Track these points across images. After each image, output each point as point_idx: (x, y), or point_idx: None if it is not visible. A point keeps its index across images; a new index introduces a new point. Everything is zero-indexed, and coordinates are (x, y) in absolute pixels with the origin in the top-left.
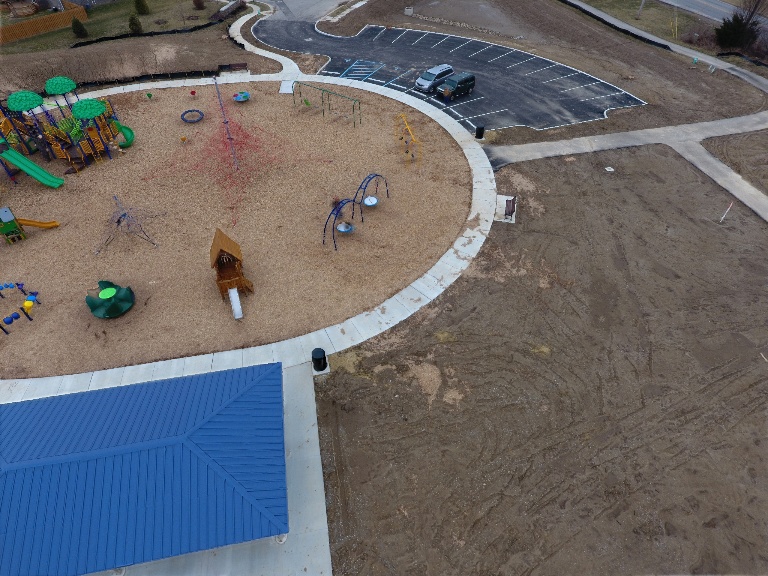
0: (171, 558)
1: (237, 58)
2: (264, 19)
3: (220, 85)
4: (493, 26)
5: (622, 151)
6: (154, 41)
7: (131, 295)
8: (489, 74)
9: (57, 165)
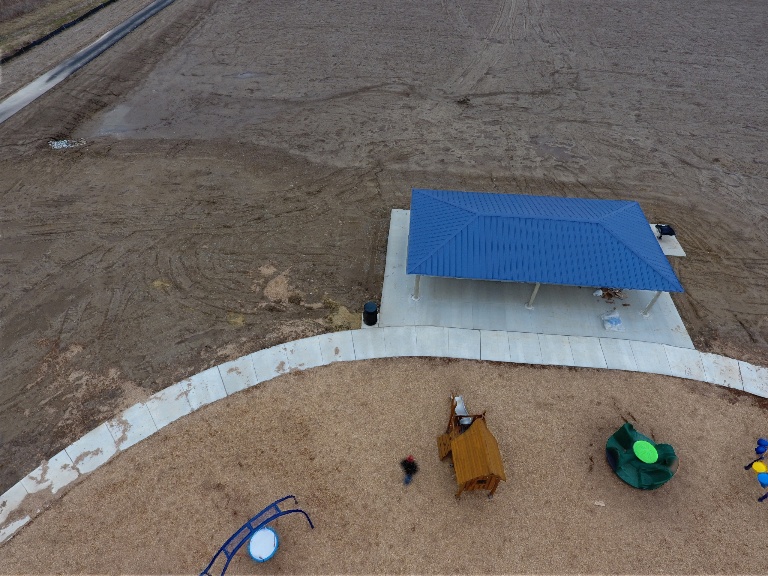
0: None
1: None
2: None
3: None
4: None
5: None
6: None
7: (615, 463)
8: None
9: None
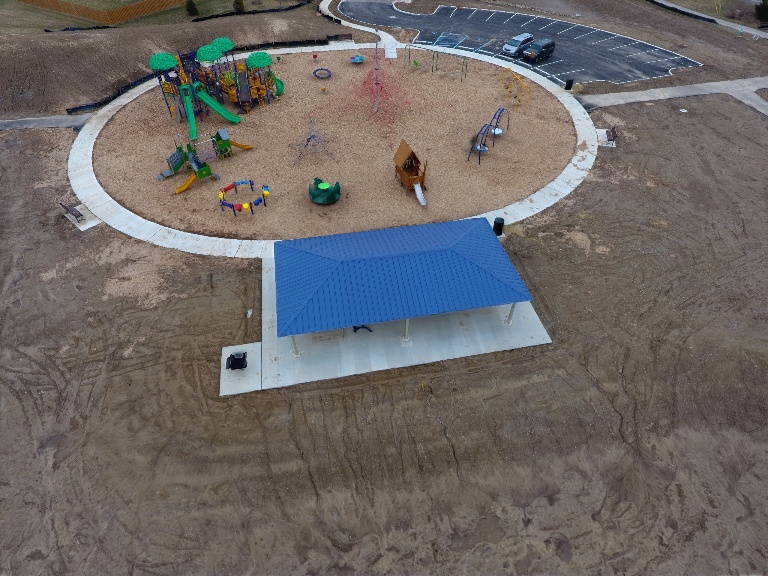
0: (438, 332)
1: (339, 31)
2: (345, 1)
3: (333, 51)
4: (550, 7)
5: (691, 98)
6: (266, 16)
7: None
8: (561, 43)
9: (227, 108)
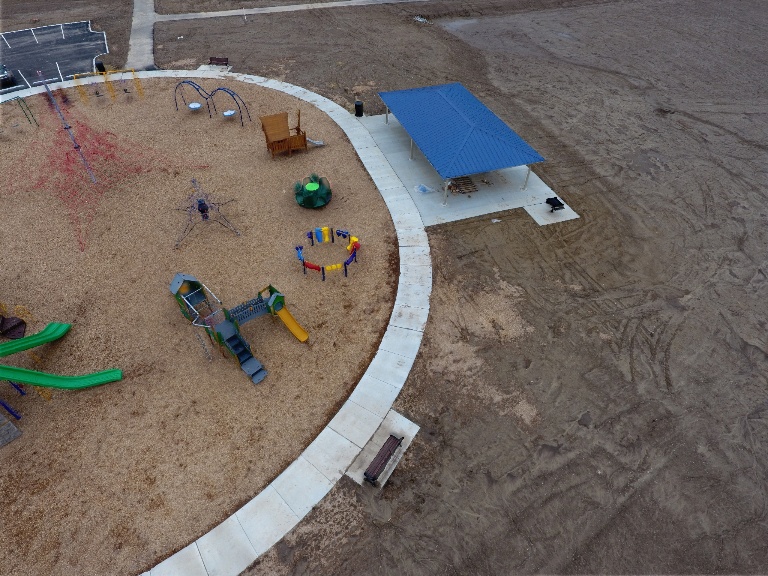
0: None
1: None
2: None
3: None
4: None
5: (158, 33)
6: None
7: None
8: None
9: None
